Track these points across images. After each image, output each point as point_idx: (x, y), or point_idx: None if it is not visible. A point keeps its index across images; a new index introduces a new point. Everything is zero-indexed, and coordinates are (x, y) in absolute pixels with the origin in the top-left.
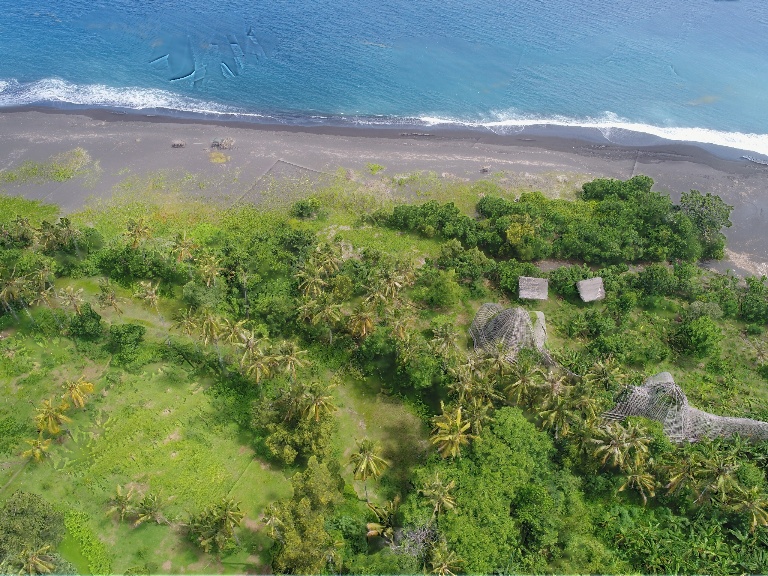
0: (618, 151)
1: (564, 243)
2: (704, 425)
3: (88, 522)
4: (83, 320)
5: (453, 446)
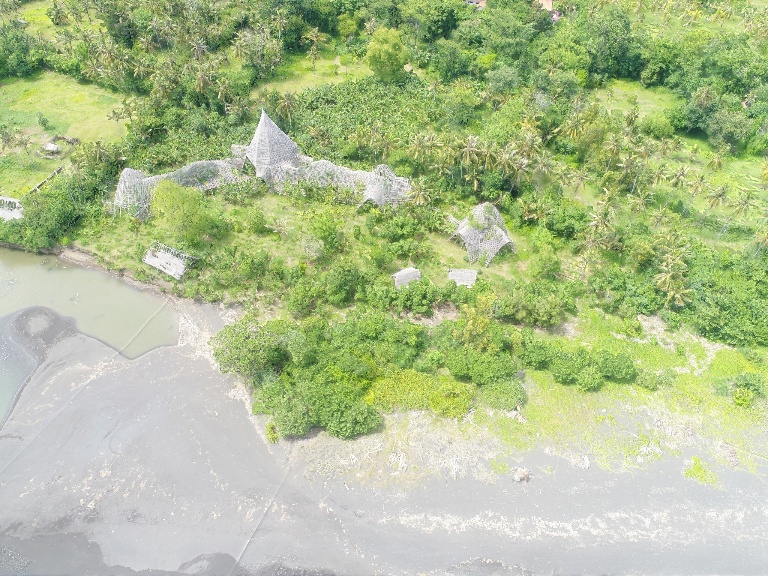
0: None
1: None
2: None
3: None
4: None
5: None
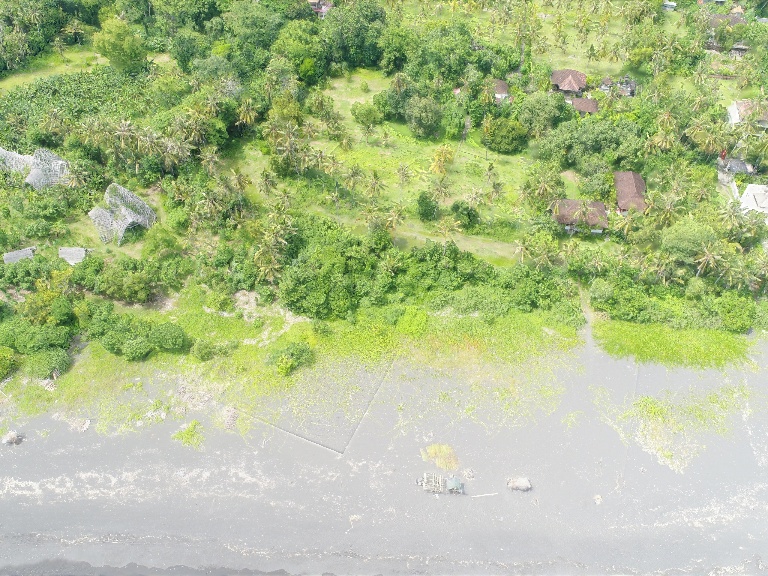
0: None
1: (4, 302)
2: None
3: (403, 141)
4: None
5: None
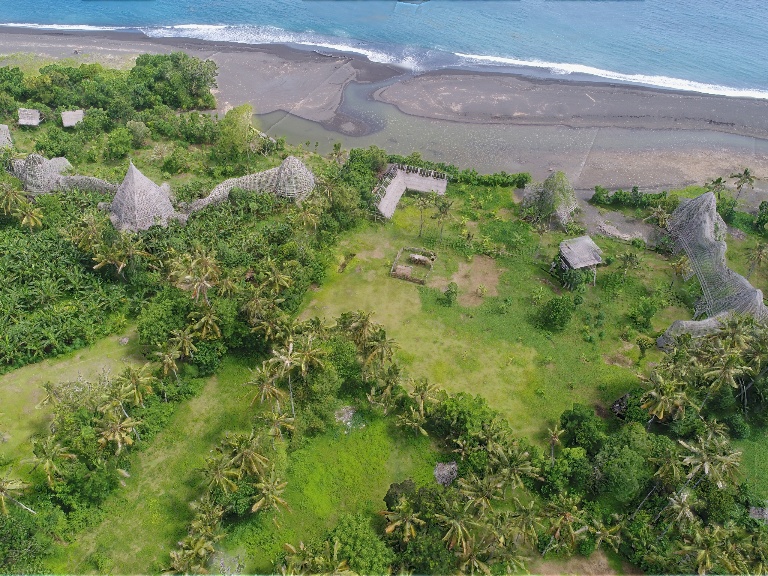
0: (214, 46)
1: None
2: (55, 182)
3: None
4: None
5: None
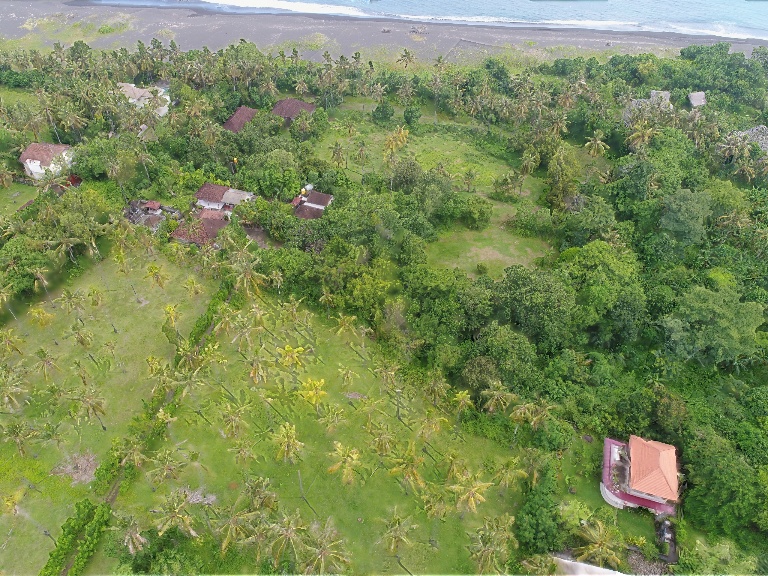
0: (698, 39)
1: (674, 79)
2: None
3: None
4: (384, 107)
5: (643, 139)
